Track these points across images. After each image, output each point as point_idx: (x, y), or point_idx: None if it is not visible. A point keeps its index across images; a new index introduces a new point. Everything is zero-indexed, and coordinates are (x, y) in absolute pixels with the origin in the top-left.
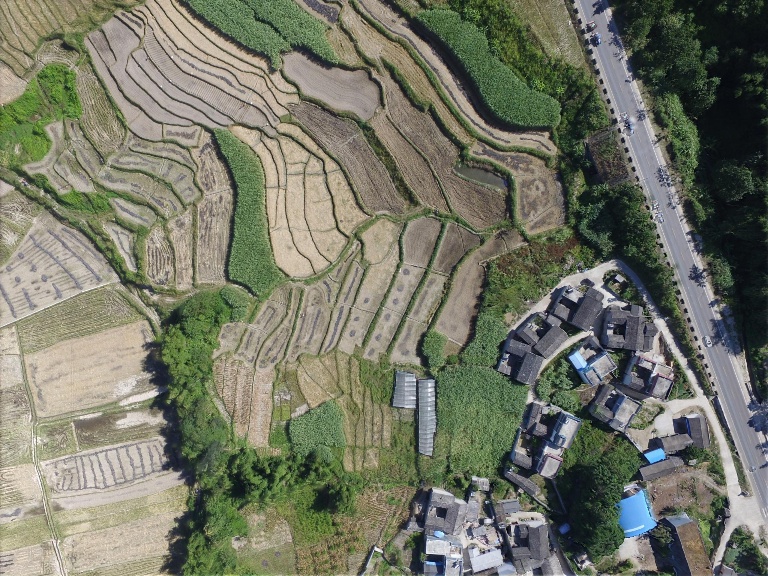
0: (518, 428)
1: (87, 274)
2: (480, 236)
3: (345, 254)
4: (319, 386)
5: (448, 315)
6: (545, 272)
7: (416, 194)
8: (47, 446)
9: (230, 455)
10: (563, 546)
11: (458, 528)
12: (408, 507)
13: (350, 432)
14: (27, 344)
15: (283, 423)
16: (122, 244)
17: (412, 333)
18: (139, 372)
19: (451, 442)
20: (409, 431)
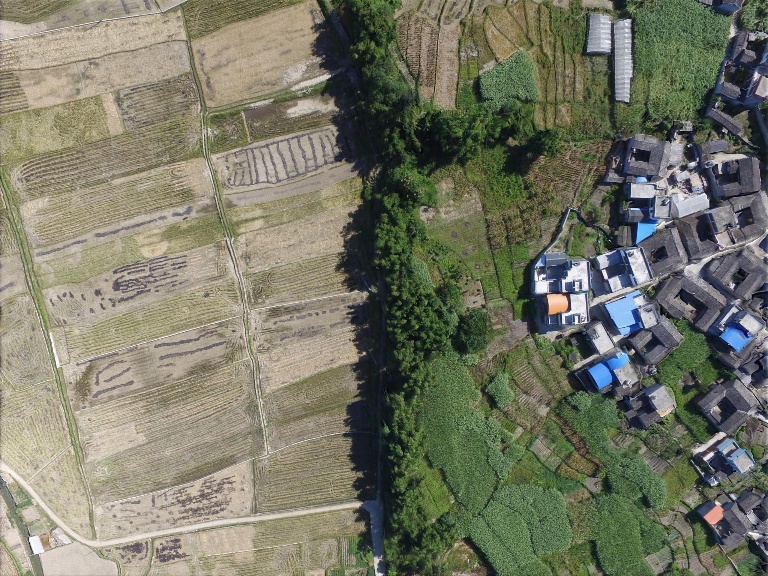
0: (722, 60)
1: None
2: None
3: None
4: (507, 39)
5: None
6: None
7: None
8: (217, 138)
9: (417, 118)
10: None
11: (663, 170)
12: (603, 163)
13: (541, 87)
14: (194, 29)
15: (470, 82)
16: None
17: None
18: (309, 56)
19: (650, 85)
20: (603, 81)
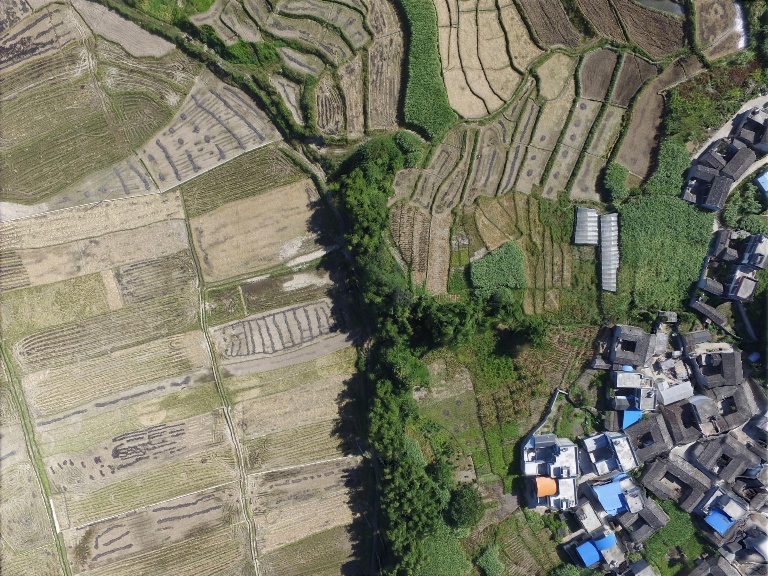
0: (706, 256)
1: (250, 133)
2: (657, 65)
3: (520, 92)
4: (497, 228)
5: (628, 147)
6: (727, 97)
7: (593, 24)
8: (215, 311)
9: (410, 303)
10: (758, 370)
11: (648, 360)
12: (591, 347)
13: (530, 274)
14: (192, 208)
15: (461, 268)
16: (288, 97)
17: (591, 169)
18: (304, 232)
19: (635, 276)
20: (590, 269)
